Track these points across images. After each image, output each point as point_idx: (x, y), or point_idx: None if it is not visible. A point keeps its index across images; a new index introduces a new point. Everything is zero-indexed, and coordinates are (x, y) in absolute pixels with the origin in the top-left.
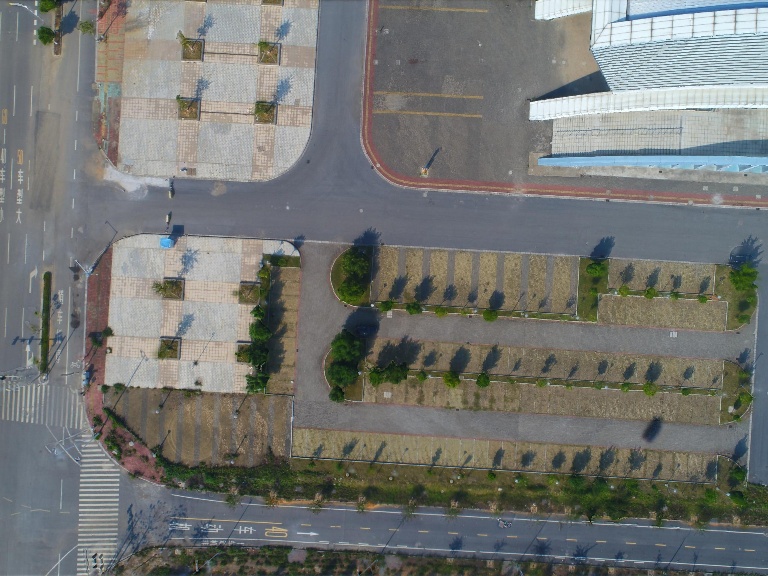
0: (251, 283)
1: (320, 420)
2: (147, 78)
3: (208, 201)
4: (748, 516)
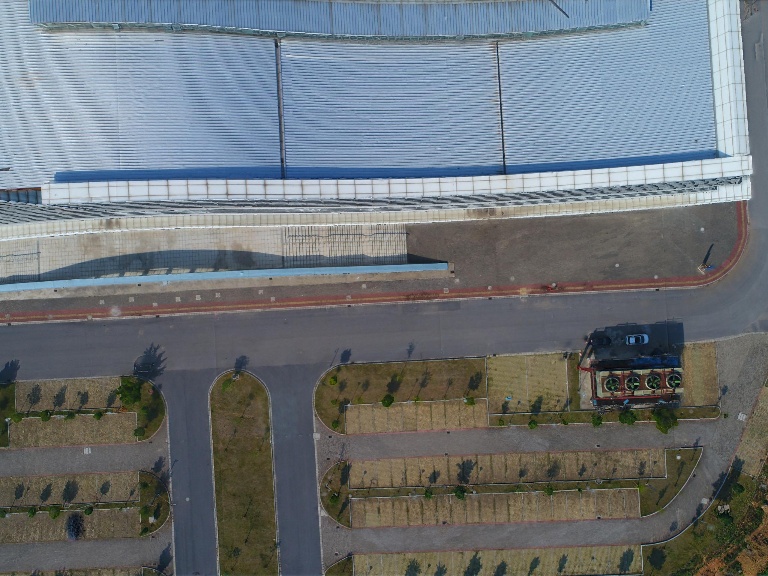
0: None
1: None
2: None
3: None
4: None
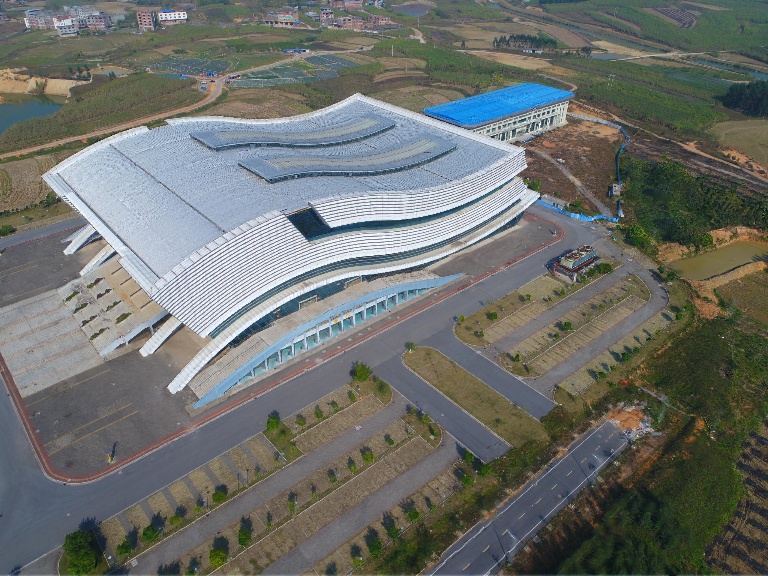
0: None
1: None
2: None
3: None
4: (512, 483)
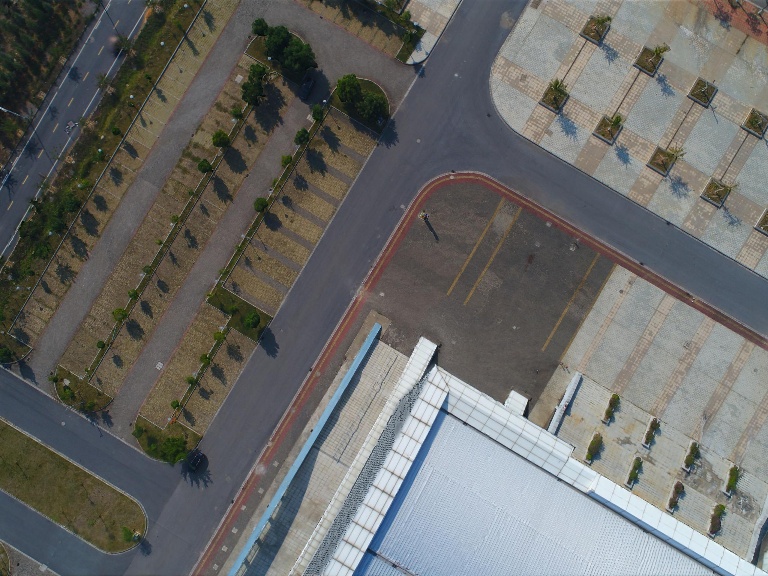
0: (404, 6)
1: (248, 6)
2: (645, 6)
3: (501, 6)
4: None
